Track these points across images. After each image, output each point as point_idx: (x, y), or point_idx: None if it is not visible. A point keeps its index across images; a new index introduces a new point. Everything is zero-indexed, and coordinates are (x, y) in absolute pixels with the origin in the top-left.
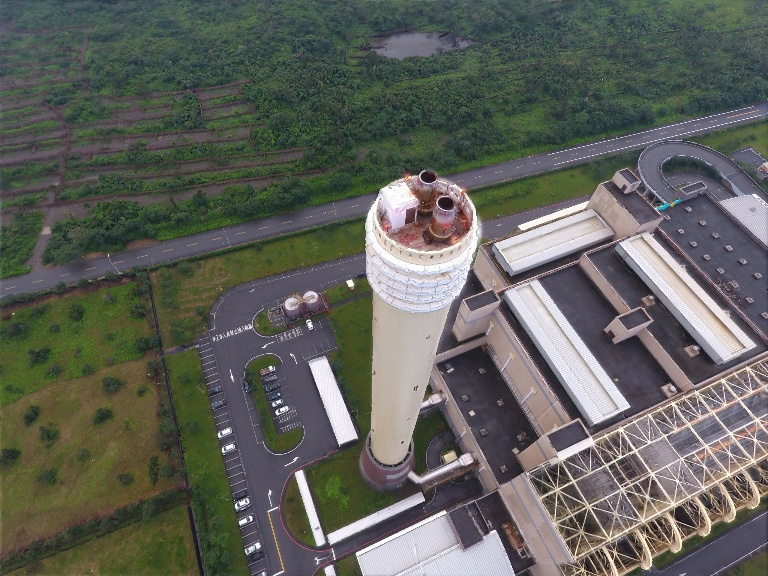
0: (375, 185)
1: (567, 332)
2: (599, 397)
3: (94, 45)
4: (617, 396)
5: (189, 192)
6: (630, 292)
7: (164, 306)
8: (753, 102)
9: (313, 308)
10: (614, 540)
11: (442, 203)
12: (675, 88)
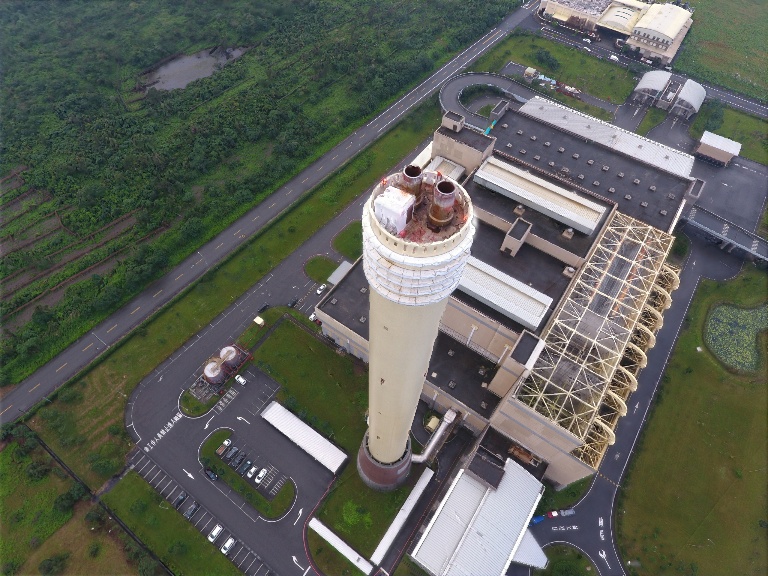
0: (228, 217)
1: (477, 265)
2: (528, 304)
3: None
4: (540, 296)
5: (23, 314)
6: (503, 210)
7: (67, 448)
8: (494, 25)
9: (235, 362)
10: (599, 407)
11: (441, 189)
12: (434, 33)
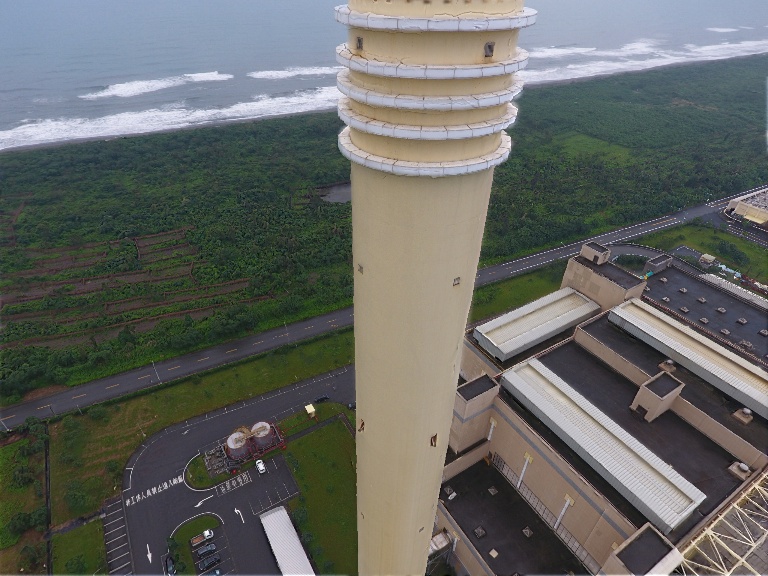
0: (330, 305)
1: (590, 412)
2: (661, 489)
3: (30, 208)
4: (683, 484)
5: (115, 331)
6: (643, 361)
7: (62, 466)
8: (668, 212)
9: (264, 444)
10: None
11: None
12: (598, 206)
